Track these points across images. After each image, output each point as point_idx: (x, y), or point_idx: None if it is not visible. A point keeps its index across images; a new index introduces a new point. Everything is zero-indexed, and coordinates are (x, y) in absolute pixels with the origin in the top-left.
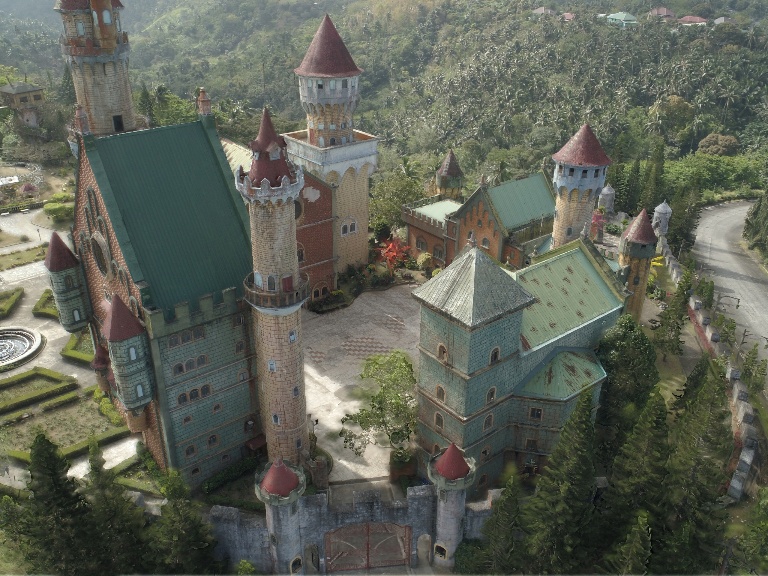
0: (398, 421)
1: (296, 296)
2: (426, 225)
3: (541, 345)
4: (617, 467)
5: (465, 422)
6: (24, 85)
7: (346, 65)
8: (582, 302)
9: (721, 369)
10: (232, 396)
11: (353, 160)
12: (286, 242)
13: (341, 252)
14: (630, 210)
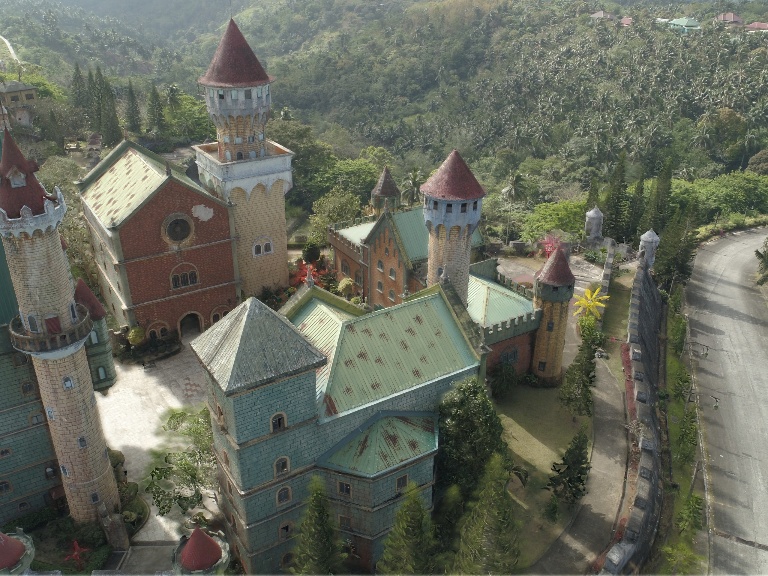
0: (211, 480)
1: (64, 339)
2: (346, 248)
3: (352, 410)
4: (378, 575)
5: (244, 496)
6: (16, 84)
7: (250, 74)
8: (424, 358)
9: (634, 436)
10: (24, 440)
11: (262, 176)
12: (44, 279)
13: (255, 273)
14: (632, 234)
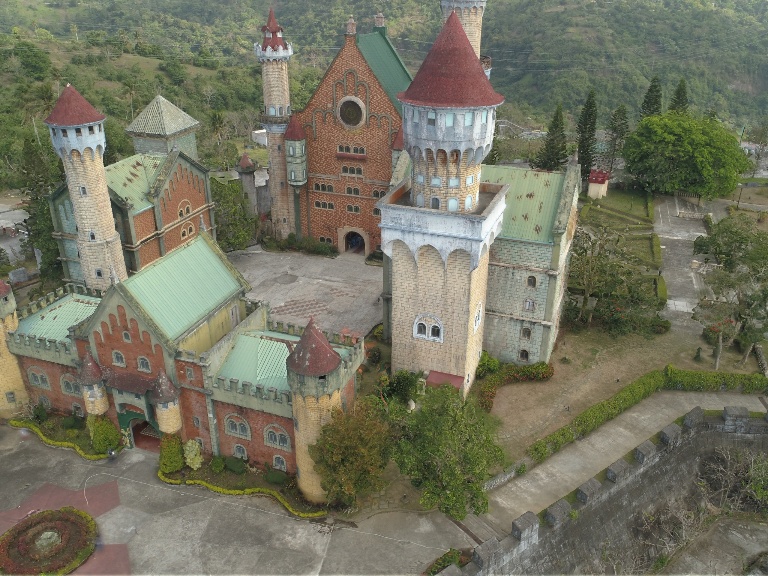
0: None
1: None
2: None
3: None
4: None
5: None
6: None
7: None
8: None
9: None
10: None
11: None
12: None
13: None
14: None
